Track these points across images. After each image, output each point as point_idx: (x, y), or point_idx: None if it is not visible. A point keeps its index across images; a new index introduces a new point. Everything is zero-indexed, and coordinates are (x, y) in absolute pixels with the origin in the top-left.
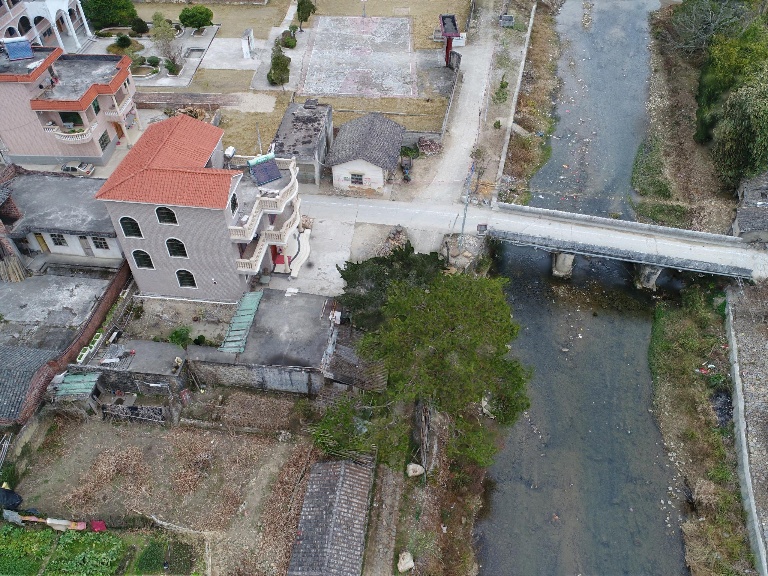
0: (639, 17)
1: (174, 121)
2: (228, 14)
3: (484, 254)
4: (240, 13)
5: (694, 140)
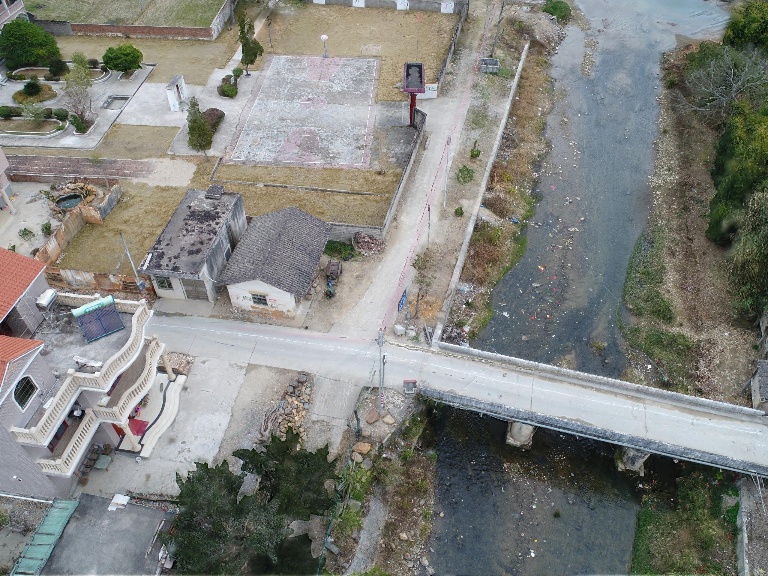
0: (650, 59)
1: None
2: (168, 52)
3: (416, 412)
4: (182, 50)
5: (706, 237)
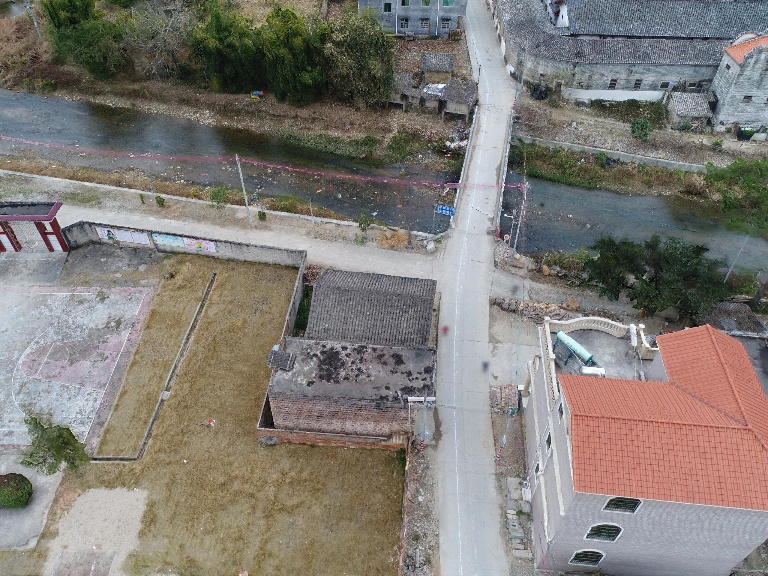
0: None
1: (596, 425)
2: None
3: None
4: None
5: None
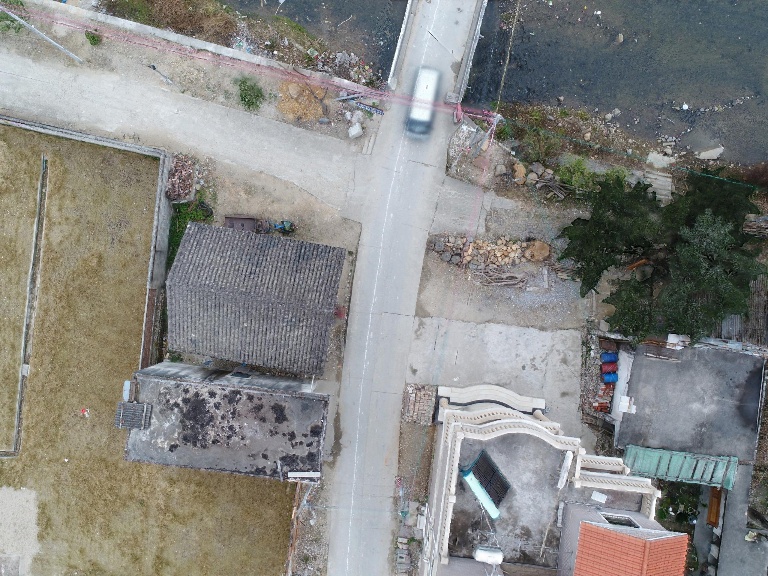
0: None
1: None
2: None
3: None
4: None
5: None
